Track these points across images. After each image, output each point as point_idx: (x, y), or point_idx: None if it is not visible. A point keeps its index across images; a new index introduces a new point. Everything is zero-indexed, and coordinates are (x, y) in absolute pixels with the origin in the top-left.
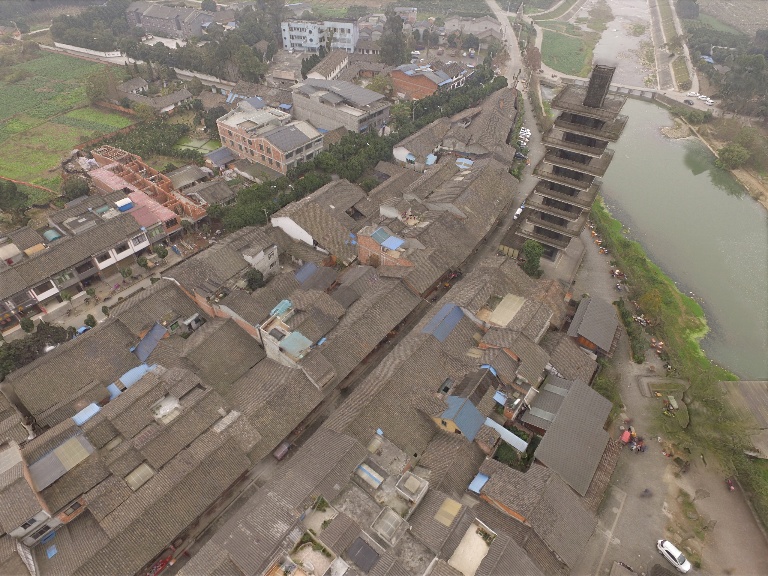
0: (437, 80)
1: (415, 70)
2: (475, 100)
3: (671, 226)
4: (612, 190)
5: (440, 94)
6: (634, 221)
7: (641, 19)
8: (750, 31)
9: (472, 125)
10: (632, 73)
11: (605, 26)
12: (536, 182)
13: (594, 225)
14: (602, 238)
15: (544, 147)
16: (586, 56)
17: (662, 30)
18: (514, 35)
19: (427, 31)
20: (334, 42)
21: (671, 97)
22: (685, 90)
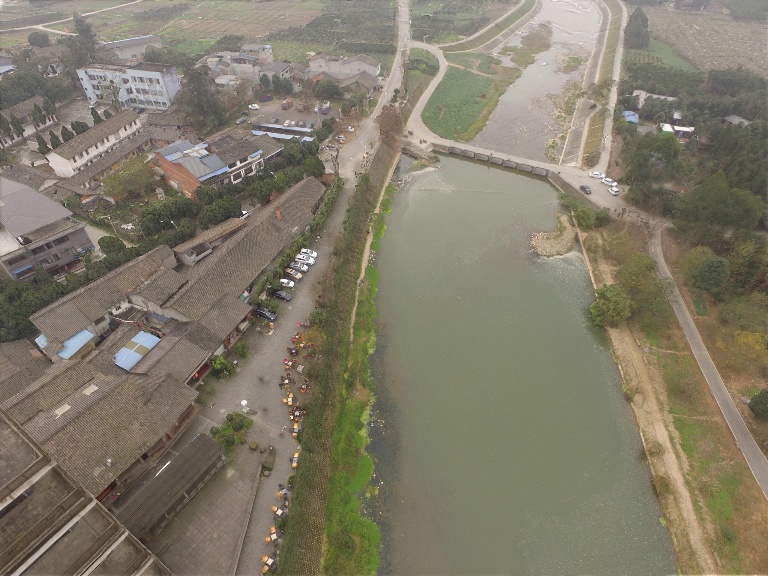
0: (199, 172)
1: (183, 152)
2: (259, 198)
3: (457, 476)
4: (399, 377)
5: (201, 193)
6: (399, 461)
7: (582, 48)
8: (709, 66)
9: (210, 255)
10: (535, 133)
11: (533, 59)
12: (258, 376)
13: (288, 505)
14: (280, 549)
15: (320, 289)
16: (486, 106)
17: (599, 65)
18: (402, 76)
19: (276, 76)
20: (145, 94)
21: (566, 179)
22: (589, 166)
